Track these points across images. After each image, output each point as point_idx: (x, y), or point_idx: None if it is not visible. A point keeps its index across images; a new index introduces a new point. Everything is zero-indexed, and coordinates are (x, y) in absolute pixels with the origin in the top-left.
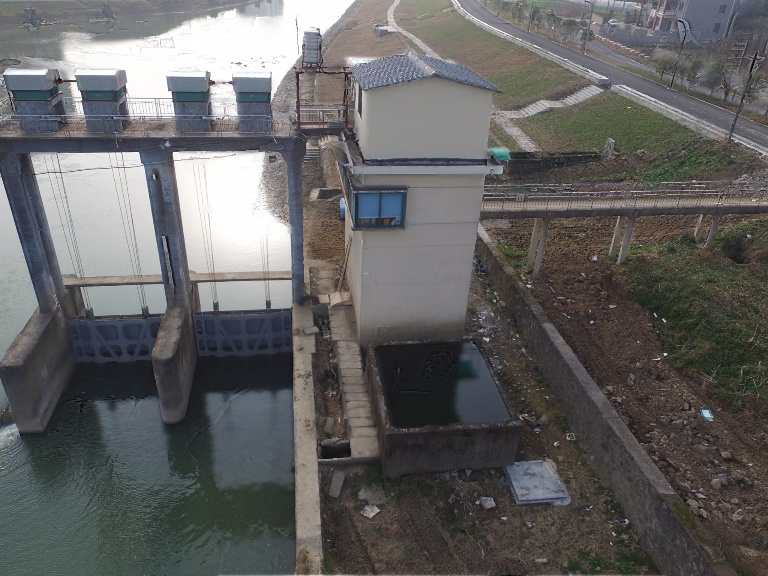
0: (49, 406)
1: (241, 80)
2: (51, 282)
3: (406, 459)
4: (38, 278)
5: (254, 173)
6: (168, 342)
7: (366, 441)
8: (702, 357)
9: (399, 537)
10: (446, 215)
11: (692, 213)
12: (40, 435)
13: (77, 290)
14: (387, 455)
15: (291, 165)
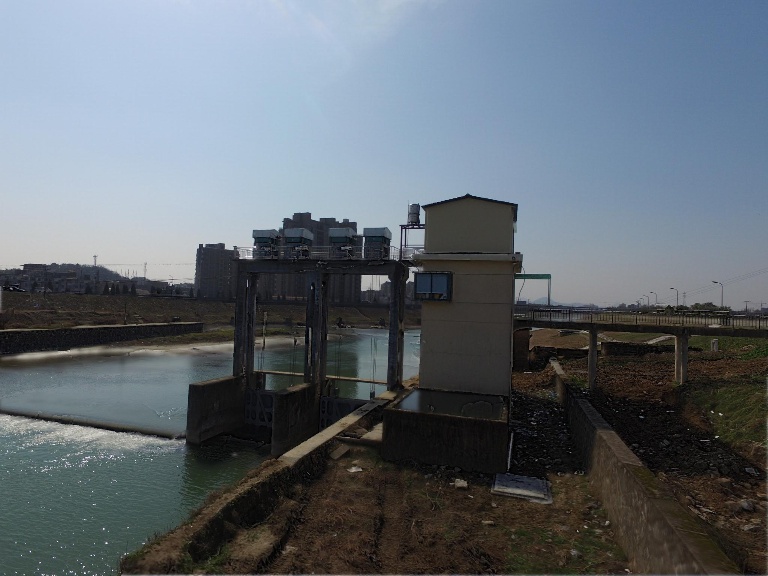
0: (210, 430)
1: (368, 229)
2: (244, 357)
3: (400, 442)
4: (237, 351)
5: None
6: (289, 390)
7: (379, 434)
8: (752, 430)
9: (365, 484)
10: (483, 296)
11: (753, 335)
12: (196, 445)
13: (263, 379)
14: (384, 433)
15: (392, 282)
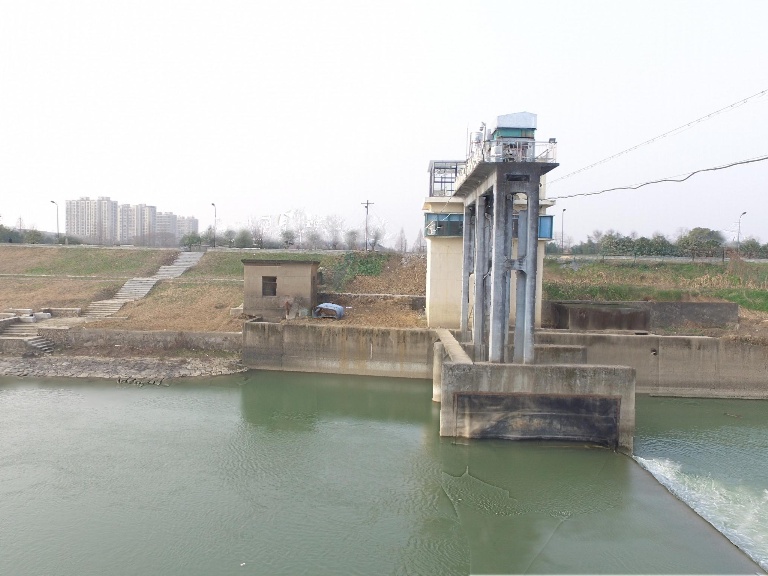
0: None
1: None
2: None
3: None
4: None
5: (8, 380)
6: (563, 345)
7: None
8: (549, 296)
9: None
10: None
11: None
12: None
13: None
14: None
15: None
